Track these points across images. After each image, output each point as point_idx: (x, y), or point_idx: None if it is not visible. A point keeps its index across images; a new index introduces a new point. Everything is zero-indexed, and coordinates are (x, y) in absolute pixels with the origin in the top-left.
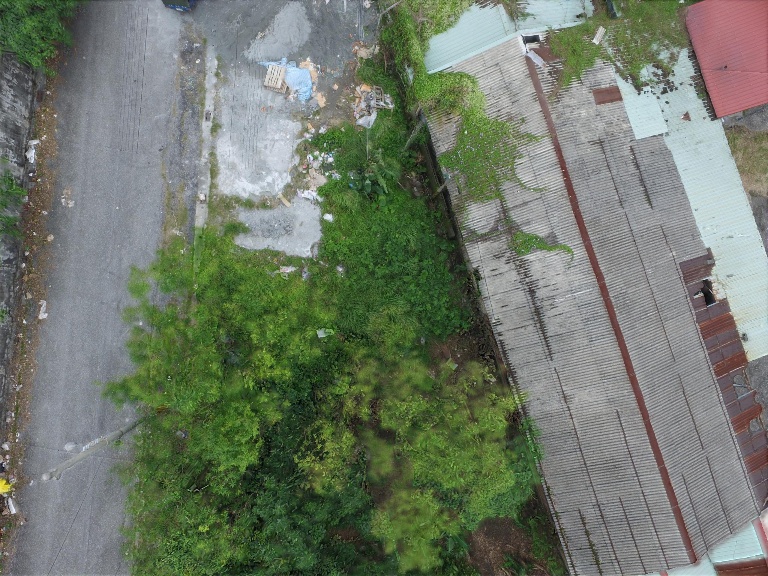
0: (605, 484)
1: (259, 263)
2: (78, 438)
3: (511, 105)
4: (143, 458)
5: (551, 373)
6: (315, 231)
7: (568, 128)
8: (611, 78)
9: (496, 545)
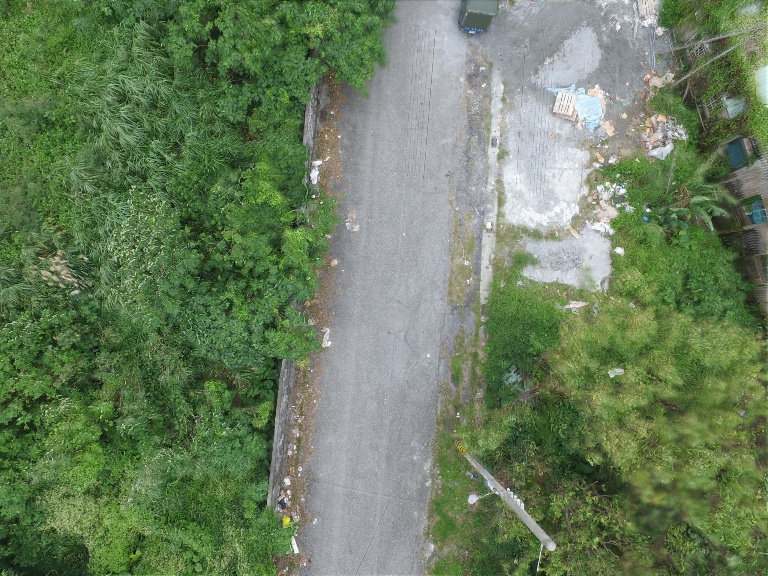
0: None
1: (549, 297)
2: (364, 475)
3: None
4: (431, 499)
5: None
6: (606, 265)
7: None
8: None
9: None
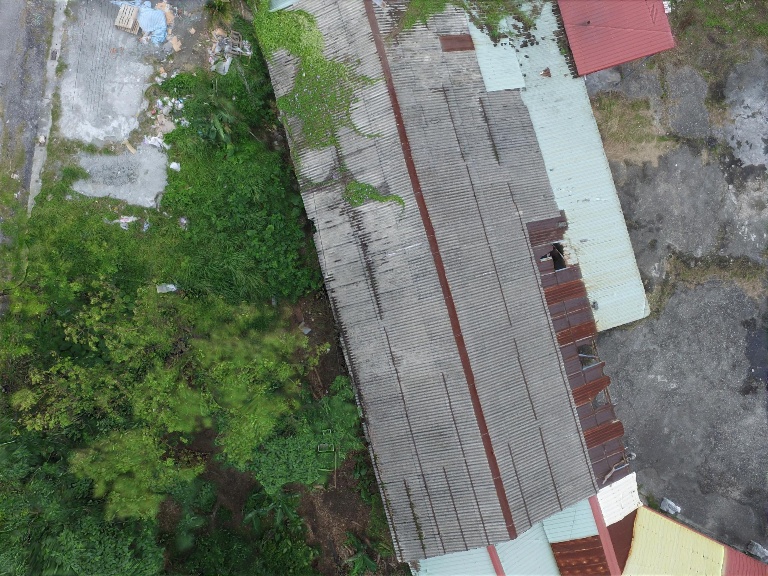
0: (430, 453)
1: (98, 211)
2: None
3: (348, 46)
4: None
5: (380, 333)
6: (161, 180)
7: (406, 72)
8: (463, 26)
9: (341, 521)
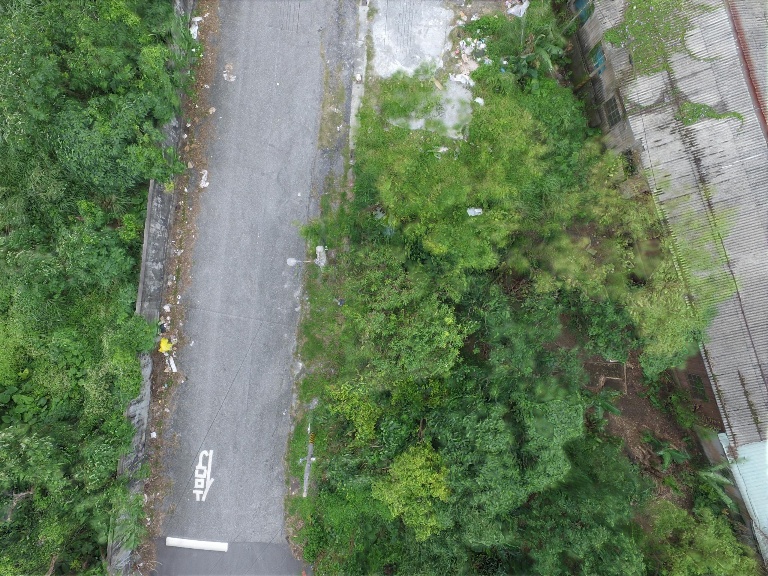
0: (767, 344)
1: (413, 142)
2: (238, 302)
3: None
4: (300, 323)
5: (714, 239)
6: (466, 114)
7: (739, 2)
8: None
9: (632, 425)
